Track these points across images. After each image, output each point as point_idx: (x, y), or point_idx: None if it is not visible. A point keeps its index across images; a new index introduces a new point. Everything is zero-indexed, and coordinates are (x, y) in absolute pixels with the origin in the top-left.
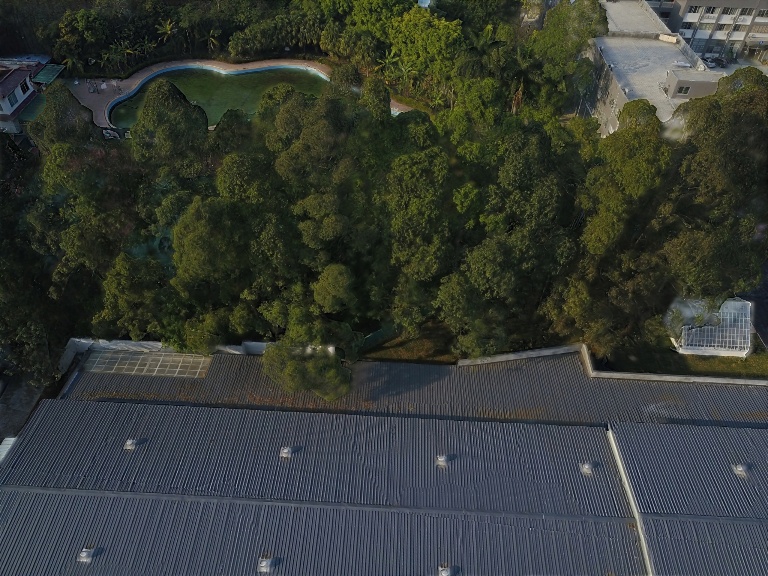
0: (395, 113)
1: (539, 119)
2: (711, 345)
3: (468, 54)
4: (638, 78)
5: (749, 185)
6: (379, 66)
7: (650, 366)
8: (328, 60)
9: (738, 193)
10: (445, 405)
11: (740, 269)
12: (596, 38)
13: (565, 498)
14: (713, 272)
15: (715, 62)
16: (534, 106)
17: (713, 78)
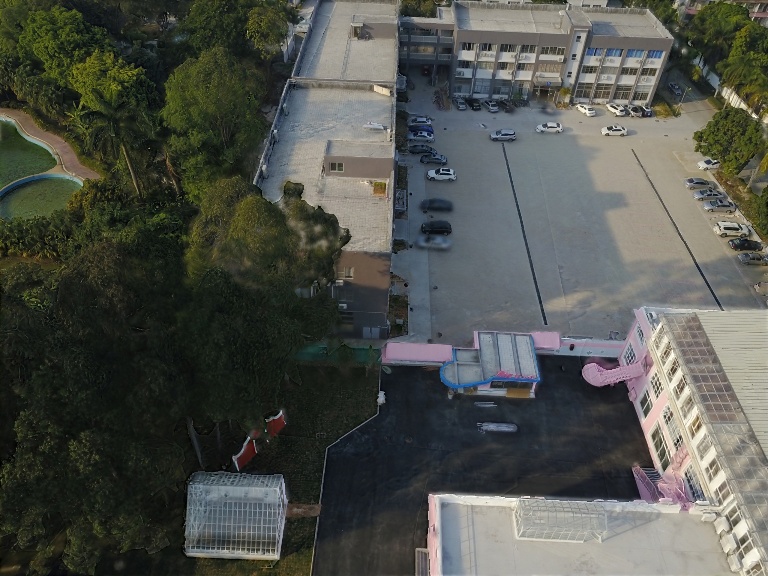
0: (72, 178)
1: (193, 196)
2: (224, 547)
3: (86, 120)
4: (307, 146)
5: (74, 391)
6: (67, 120)
7: None
8: (35, 109)
9: (36, 411)
10: None
11: (86, 510)
12: (300, 90)
13: None
14: (11, 527)
15: (499, 106)
16: (196, 178)
17: (375, 151)
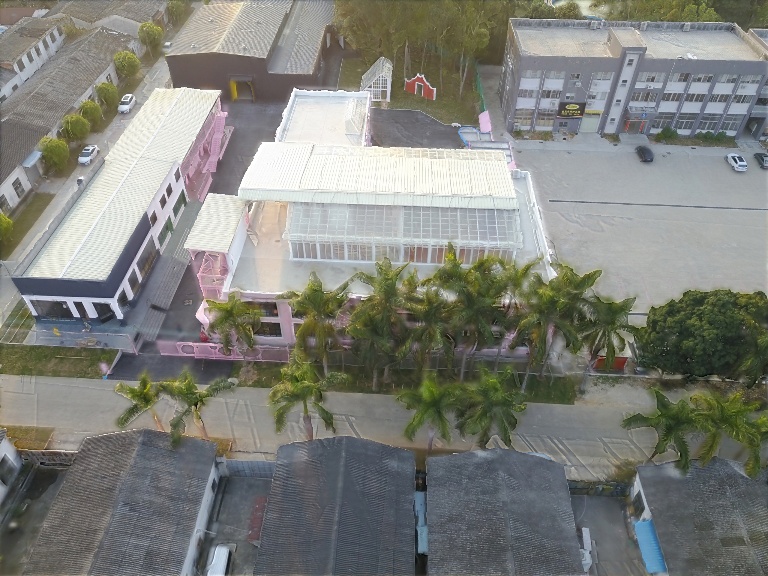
0: None
1: None
2: None
3: None
4: None
5: None
6: None
7: (353, 73)
8: None
9: None
10: (311, 1)
11: None
12: (733, 34)
13: (258, 0)
14: None
15: None
16: None
17: (631, 43)
